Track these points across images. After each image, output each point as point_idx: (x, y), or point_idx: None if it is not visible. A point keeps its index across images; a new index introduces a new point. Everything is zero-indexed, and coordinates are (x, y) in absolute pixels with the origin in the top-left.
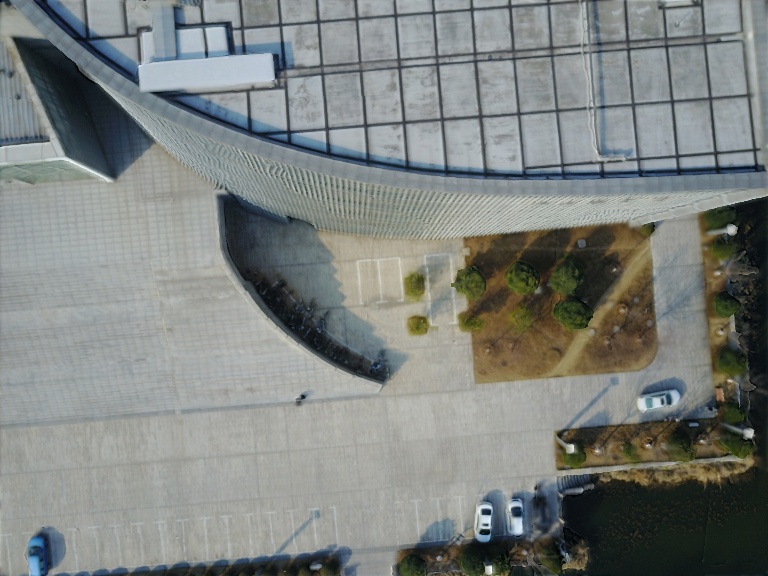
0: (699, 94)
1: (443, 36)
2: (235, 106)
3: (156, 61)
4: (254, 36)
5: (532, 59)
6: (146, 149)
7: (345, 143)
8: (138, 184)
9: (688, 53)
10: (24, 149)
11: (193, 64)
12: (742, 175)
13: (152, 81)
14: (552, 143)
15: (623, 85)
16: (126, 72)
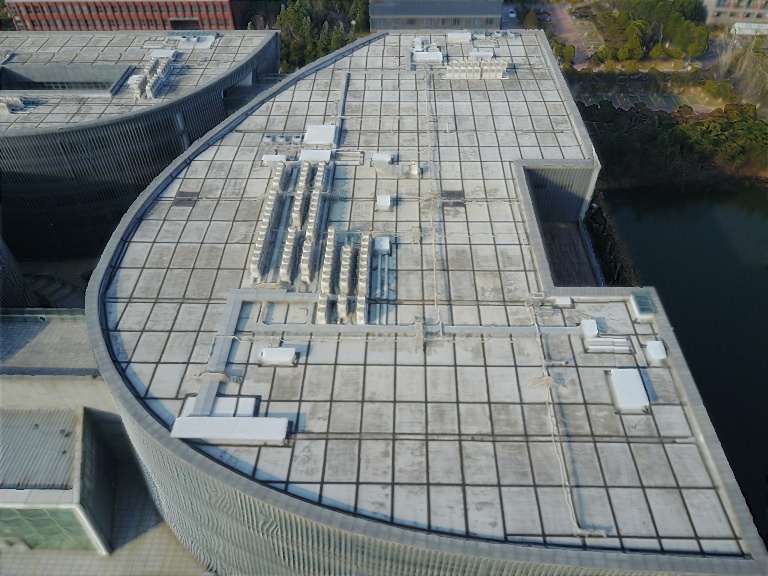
0: (667, 483)
1: (433, 419)
2: (246, 457)
3: (192, 416)
4: (277, 407)
5: (509, 443)
6: (153, 525)
7: (336, 496)
8: (132, 559)
9: (649, 449)
10: (46, 493)
11: (221, 420)
12: (730, 561)
13: (183, 430)
14: (532, 514)
15: (594, 470)
16: (164, 423)
